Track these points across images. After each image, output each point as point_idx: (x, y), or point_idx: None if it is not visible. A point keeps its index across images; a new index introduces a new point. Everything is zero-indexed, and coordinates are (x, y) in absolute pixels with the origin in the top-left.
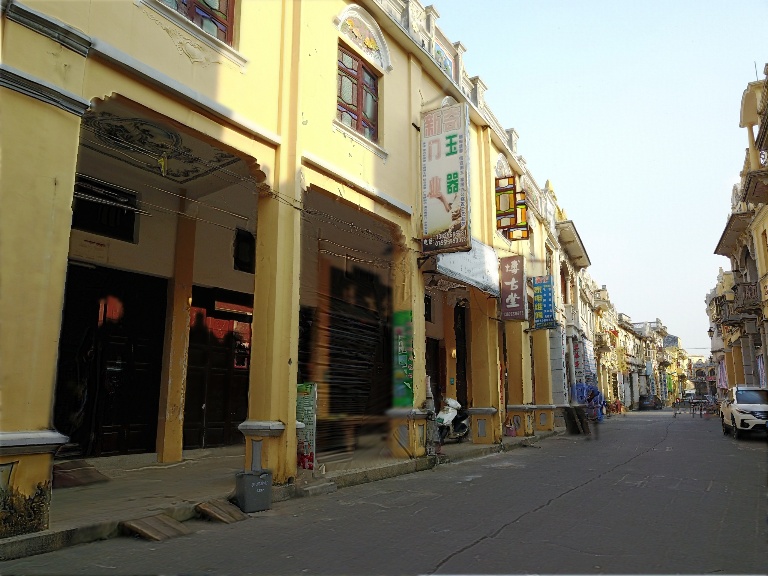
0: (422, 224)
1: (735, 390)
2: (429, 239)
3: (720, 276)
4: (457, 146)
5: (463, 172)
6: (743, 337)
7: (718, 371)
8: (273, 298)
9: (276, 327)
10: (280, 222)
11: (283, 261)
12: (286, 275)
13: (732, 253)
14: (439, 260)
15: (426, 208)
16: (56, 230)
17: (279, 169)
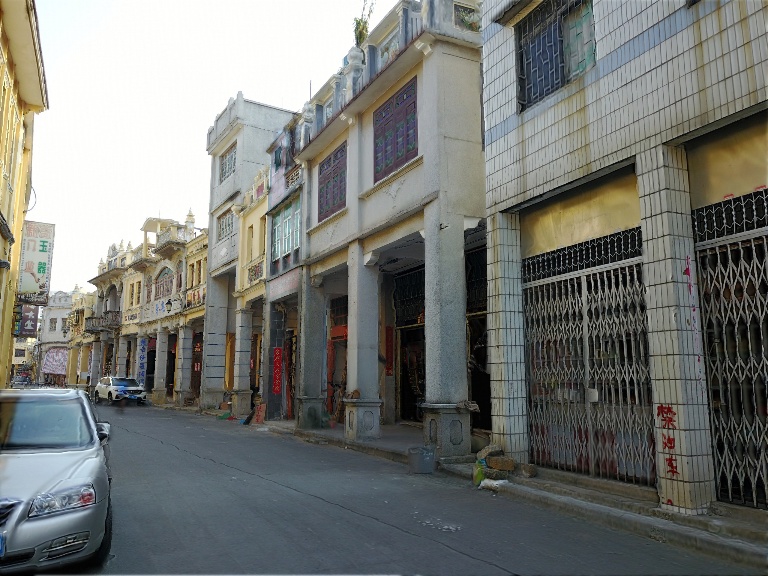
0: (18, 286)
1: (111, 378)
2: (22, 295)
3: (75, 291)
4: (47, 248)
5: (50, 264)
6: (96, 341)
7: (44, 359)
8: (2, 337)
9: (2, 351)
10: (7, 299)
11: (6, 318)
12: (8, 325)
13: (101, 285)
14: (22, 307)
15: (22, 277)
16: (1, 320)
17: (9, 272)
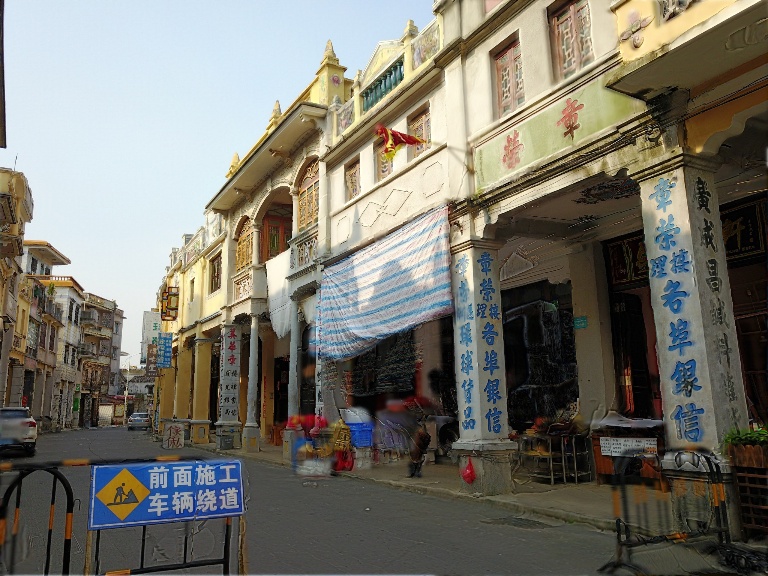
0: None
1: None
2: None
3: None
4: None
5: None
6: None
7: None
8: None
9: None
10: None
11: None
12: None
13: None
14: None
15: None
16: None
17: None
